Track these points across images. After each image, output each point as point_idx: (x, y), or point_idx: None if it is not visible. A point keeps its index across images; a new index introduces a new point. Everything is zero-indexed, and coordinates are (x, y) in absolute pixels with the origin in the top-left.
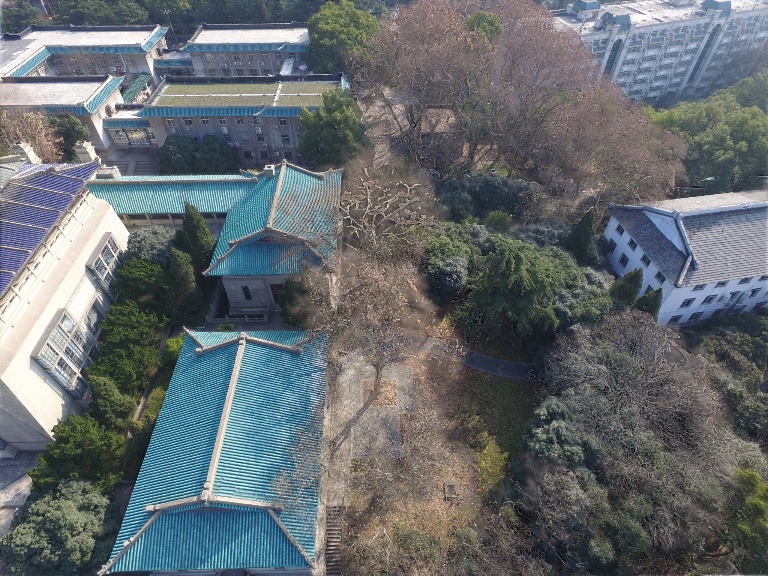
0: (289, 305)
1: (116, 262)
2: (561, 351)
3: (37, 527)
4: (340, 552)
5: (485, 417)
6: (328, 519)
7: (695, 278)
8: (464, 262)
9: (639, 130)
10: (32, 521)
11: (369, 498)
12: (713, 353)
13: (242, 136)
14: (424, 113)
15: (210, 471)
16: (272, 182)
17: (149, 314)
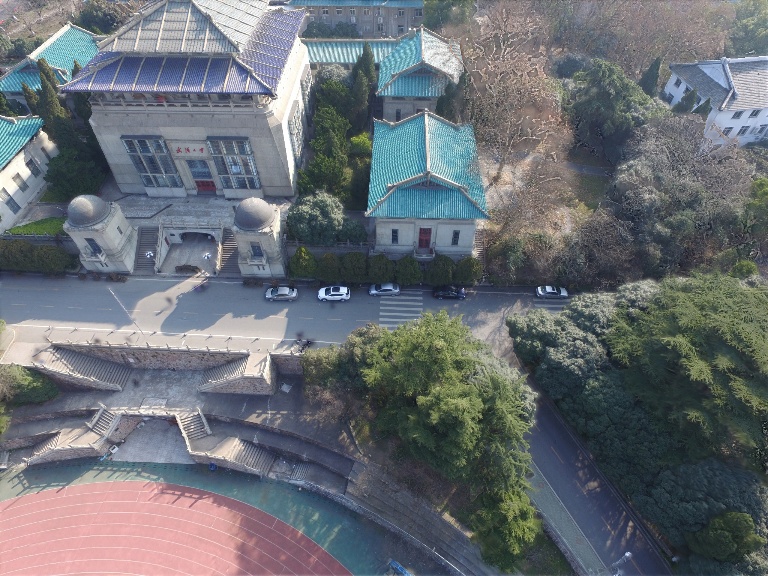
0: (445, 106)
1: (310, 88)
2: (635, 140)
3: (311, 207)
4: (483, 255)
5: (575, 193)
6: (475, 236)
7: (734, 105)
8: (560, 96)
9: (700, 1)
10: (307, 204)
11: (501, 226)
12: (743, 158)
13: (366, 26)
14: (522, 0)
15: (428, 162)
16: (414, 40)
17: (341, 117)
